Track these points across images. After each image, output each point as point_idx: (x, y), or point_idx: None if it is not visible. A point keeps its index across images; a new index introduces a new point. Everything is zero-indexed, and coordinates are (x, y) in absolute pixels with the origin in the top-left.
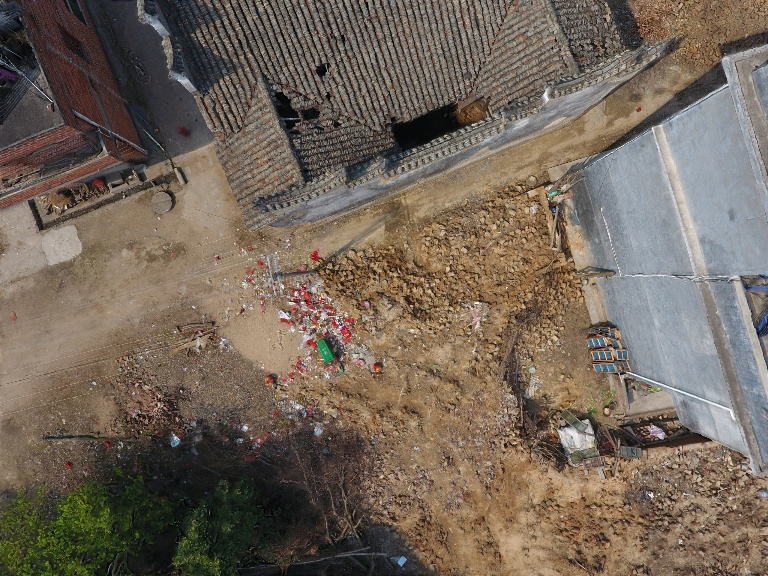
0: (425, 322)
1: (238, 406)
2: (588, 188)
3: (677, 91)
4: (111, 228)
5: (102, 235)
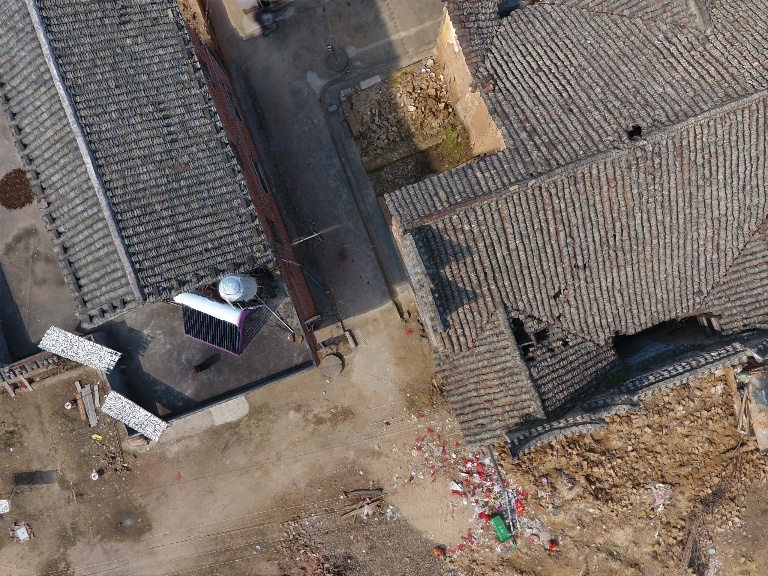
0: (607, 504)
1: None
2: None
3: None
4: (279, 389)
5: (269, 396)
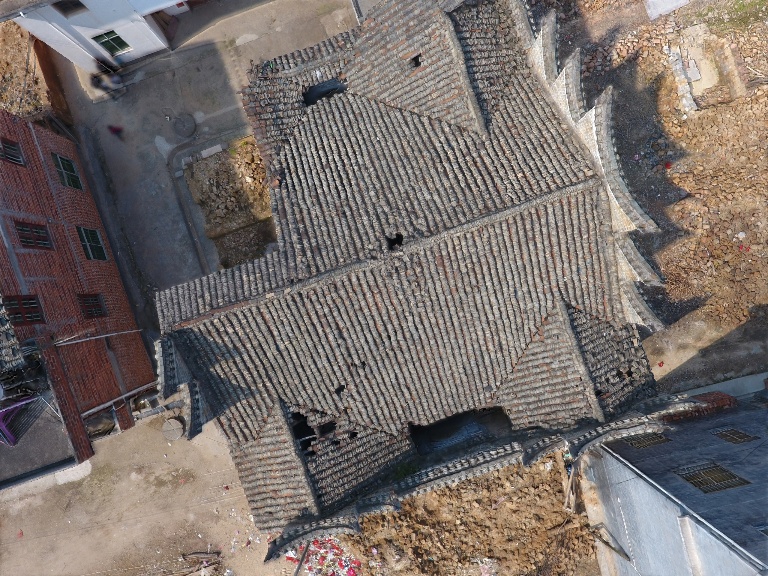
0: None
1: None
2: (606, 469)
3: (701, 347)
4: (121, 451)
5: (112, 457)
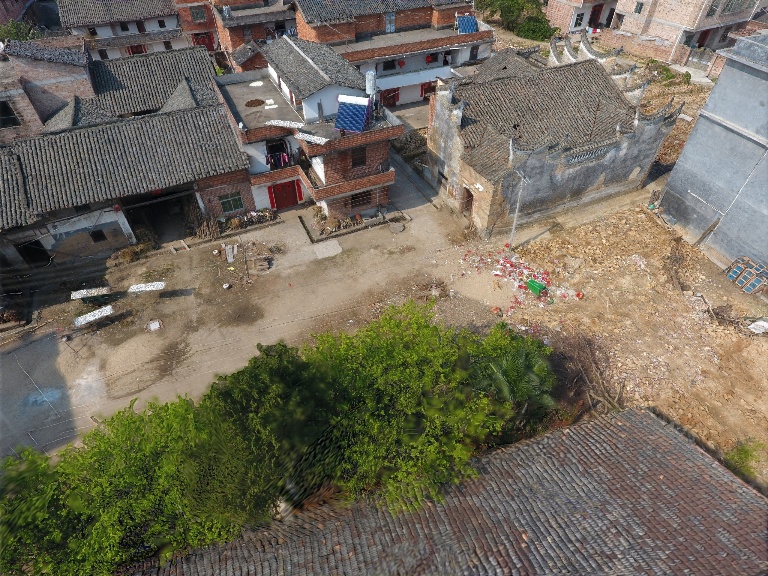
0: None
1: (476, 325)
2: (673, 191)
3: None
4: (362, 241)
5: (356, 244)
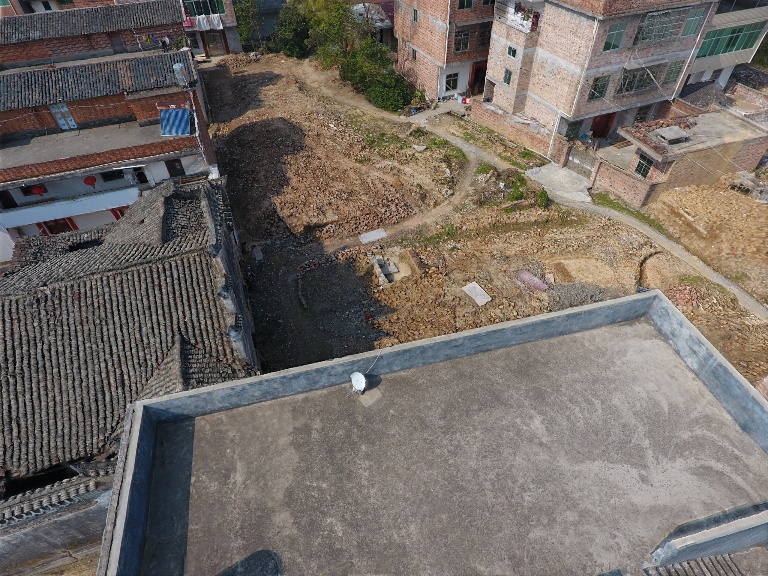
0: None
1: None
2: None
3: None
4: None
5: None
